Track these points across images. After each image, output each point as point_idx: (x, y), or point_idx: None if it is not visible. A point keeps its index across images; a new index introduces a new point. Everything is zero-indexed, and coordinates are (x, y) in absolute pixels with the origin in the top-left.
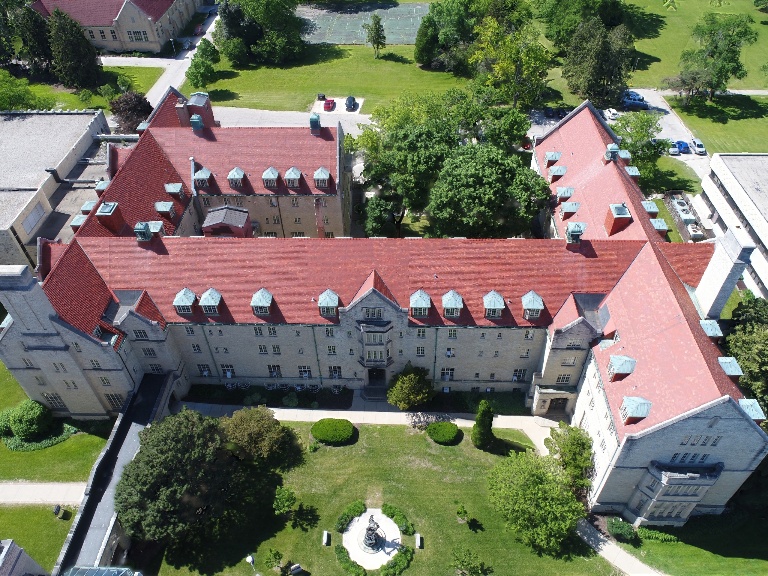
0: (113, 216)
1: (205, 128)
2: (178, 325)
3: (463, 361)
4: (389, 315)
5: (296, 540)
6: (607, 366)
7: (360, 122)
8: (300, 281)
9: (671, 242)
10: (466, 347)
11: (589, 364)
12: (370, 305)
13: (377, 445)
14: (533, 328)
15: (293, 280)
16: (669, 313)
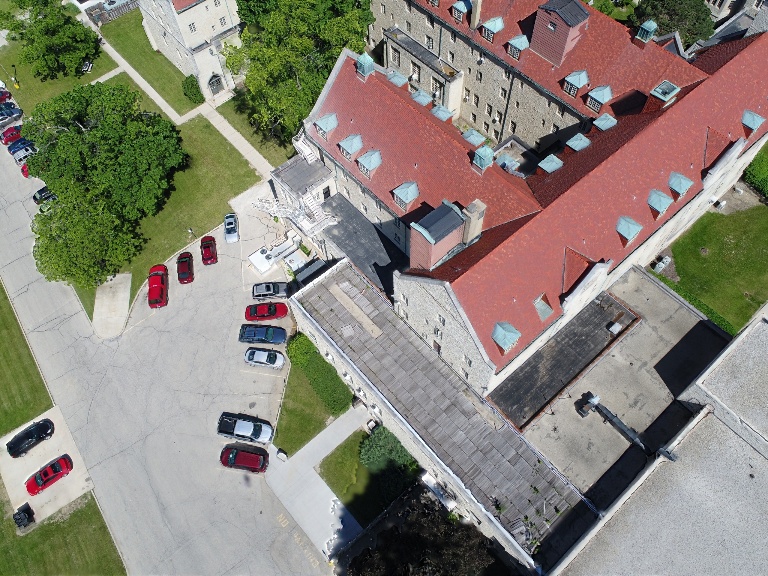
0: None
1: None
2: None
3: None
4: None
5: None
6: None
7: (84, 379)
8: None
9: None
10: None
11: None
12: None
13: None
14: None
15: None
16: None
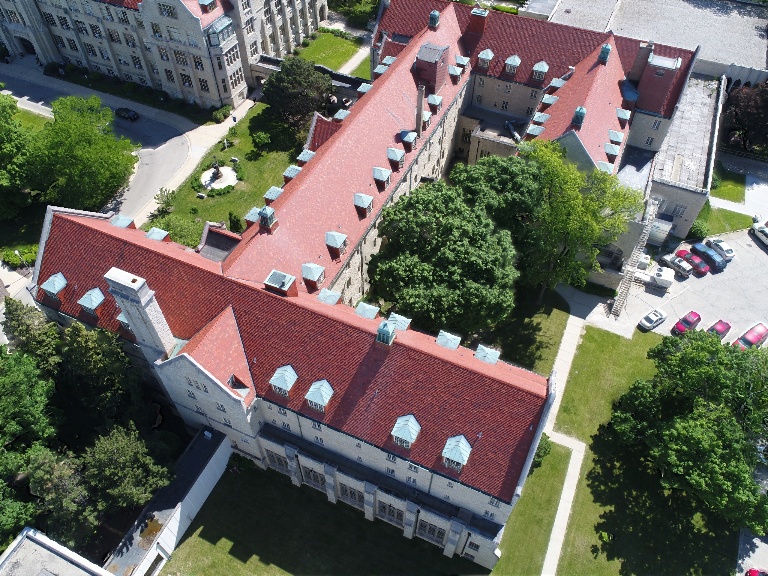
0: (474, 17)
1: (602, 62)
2: None
3: None
4: None
5: (244, 150)
6: None
7: None
8: None
9: (220, 318)
10: None
11: None
12: None
13: None
14: None
15: None
16: (144, 244)
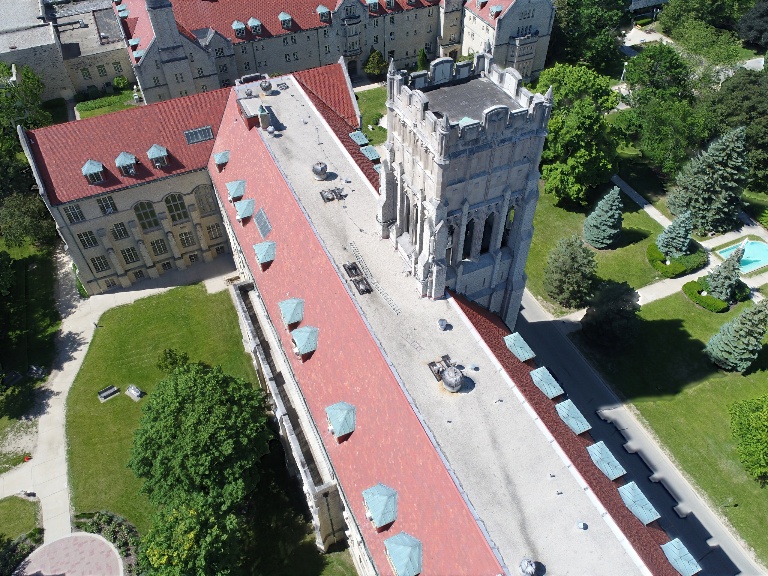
0: None
1: None
2: (238, 45)
3: (399, 42)
4: (359, 11)
5: None
6: (475, 6)
7: None
8: (302, 3)
9: None
10: (400, 30)
11: (465, 17)
12: (348, 4)
13: (370, 97)
14: (432, 6)
15: (298, 3)
16: None
